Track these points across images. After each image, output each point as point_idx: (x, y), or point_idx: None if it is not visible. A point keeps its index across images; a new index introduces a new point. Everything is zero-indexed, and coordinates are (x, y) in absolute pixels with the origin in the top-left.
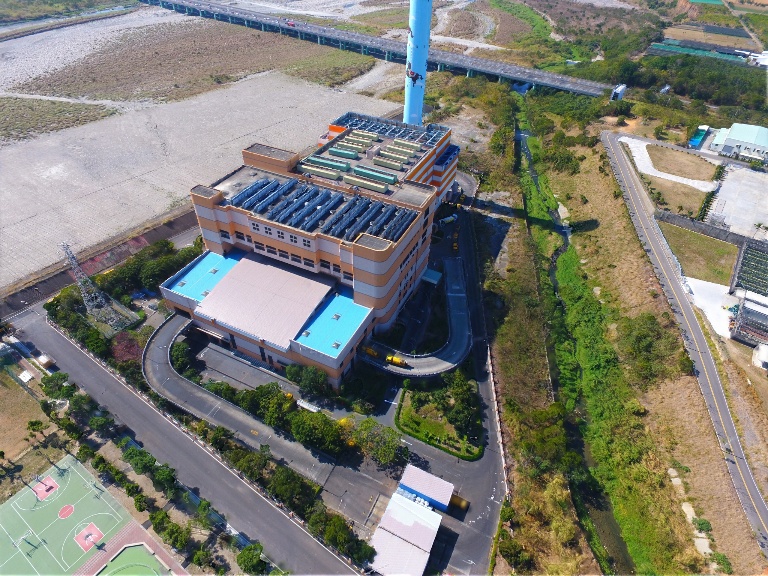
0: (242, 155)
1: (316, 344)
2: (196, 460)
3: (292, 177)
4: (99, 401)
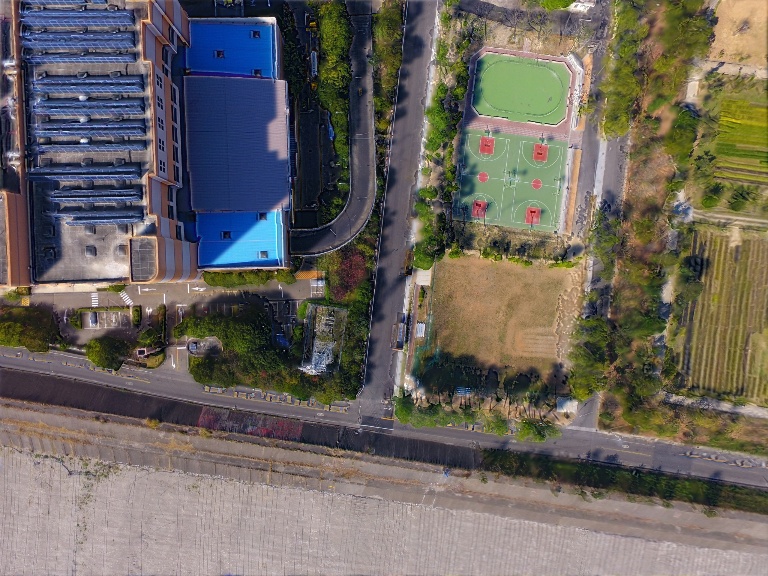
0: None
1: (264, 55)
2: (405, 120)
3: (27, 186)
4: (404, 245)
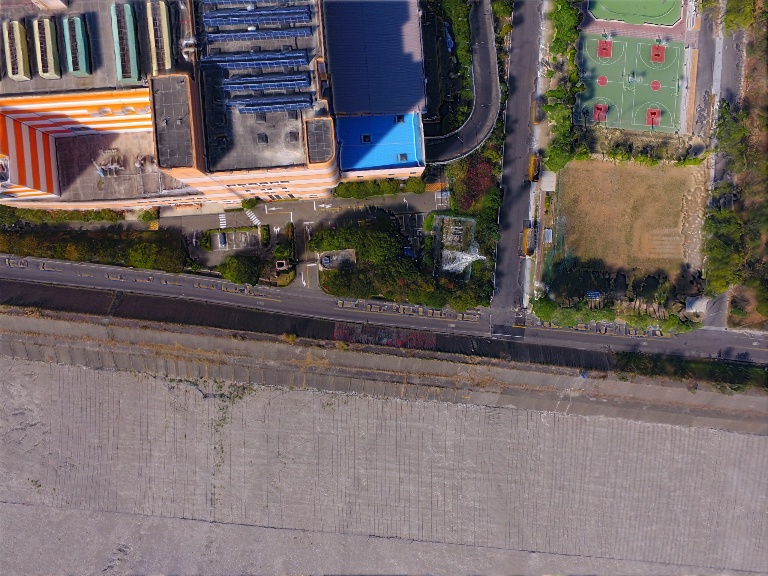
0: (200, 172)
1: None
2: (522, 28)
3: (199, 75)
4: (527, 153)
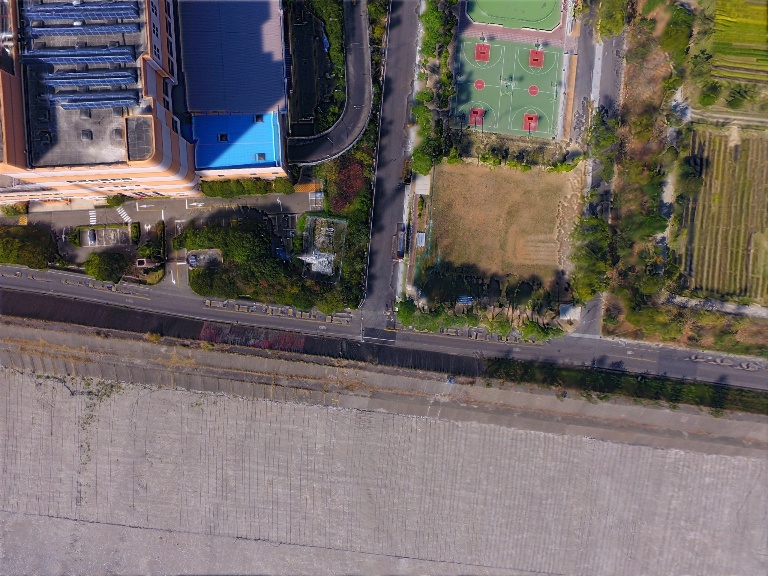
0: None
1: None
2: (399, 29)
3: (21, 69)
4: (402, 155)
